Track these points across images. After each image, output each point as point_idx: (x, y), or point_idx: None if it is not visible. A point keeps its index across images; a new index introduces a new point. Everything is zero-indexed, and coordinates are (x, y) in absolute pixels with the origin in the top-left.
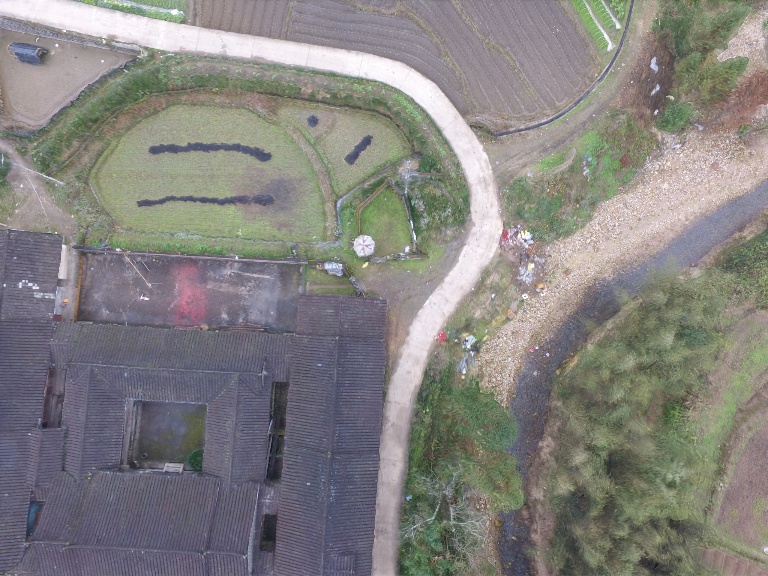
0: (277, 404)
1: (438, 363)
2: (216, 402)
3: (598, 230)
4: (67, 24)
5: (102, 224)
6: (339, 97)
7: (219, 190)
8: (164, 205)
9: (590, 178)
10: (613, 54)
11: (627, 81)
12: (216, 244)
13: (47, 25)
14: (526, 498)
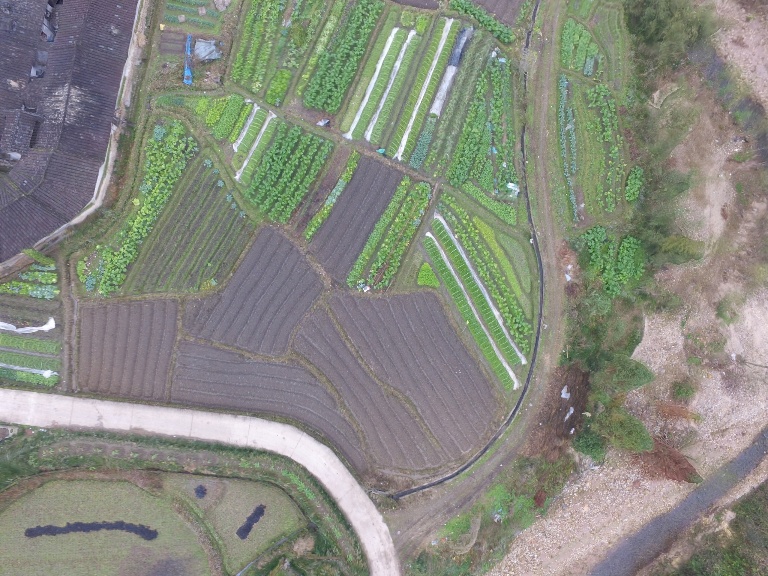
0: None
1: None
2: None
3: (516, 563)
4: None
5: None
6: None
7: (102, 575)
8: None
9: (503, 518)
10: (520, 394)
11: (535, 423)
12: None
13: None
14: None
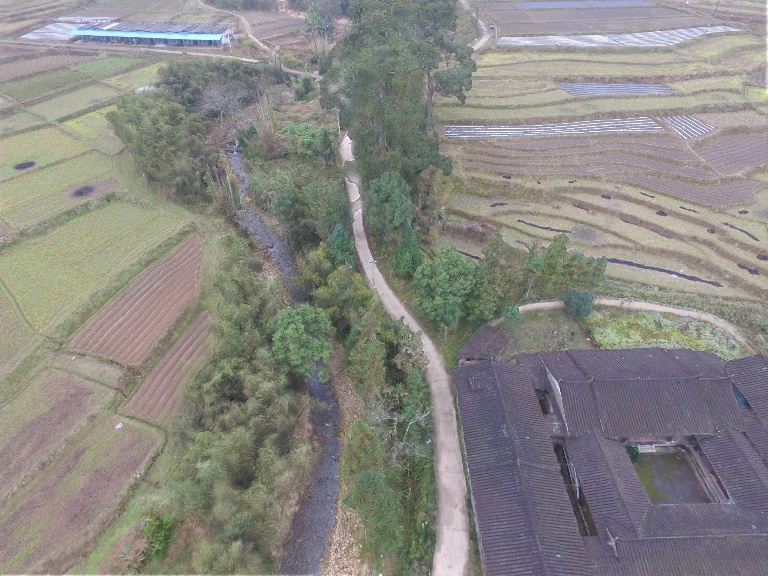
0: (579, 517)
1: None
2: (645, 507)
3: None
4: None
5: None
6: None
7: None
8: None
9: None
10: None
11: None
12: None
13: None
14: (315, 457)
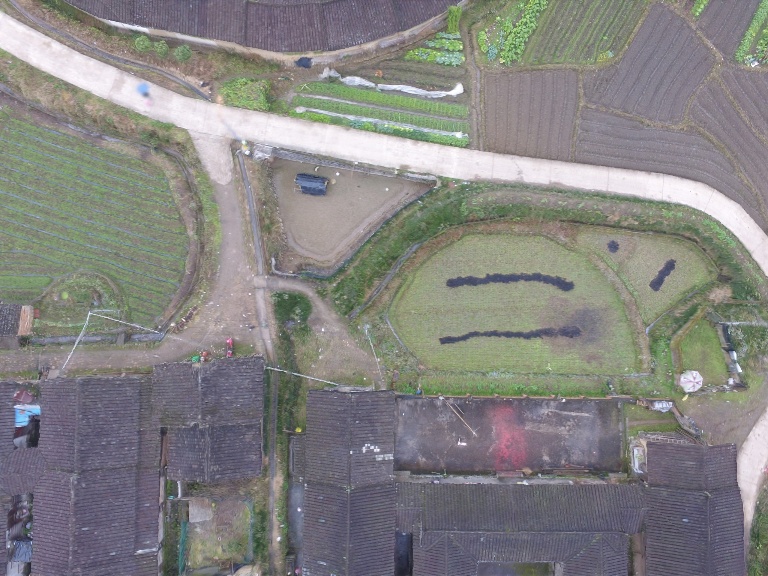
0: None
1: (766, 496)
2: (574, 561)
3: None
4: (359, 156)
5: (412, 367)
6: (646, 223)
7: (523, 323)
8: (468, 341)
9: None
10: None
11: None
12: (530, 382)
13: (339, 158)
14: None
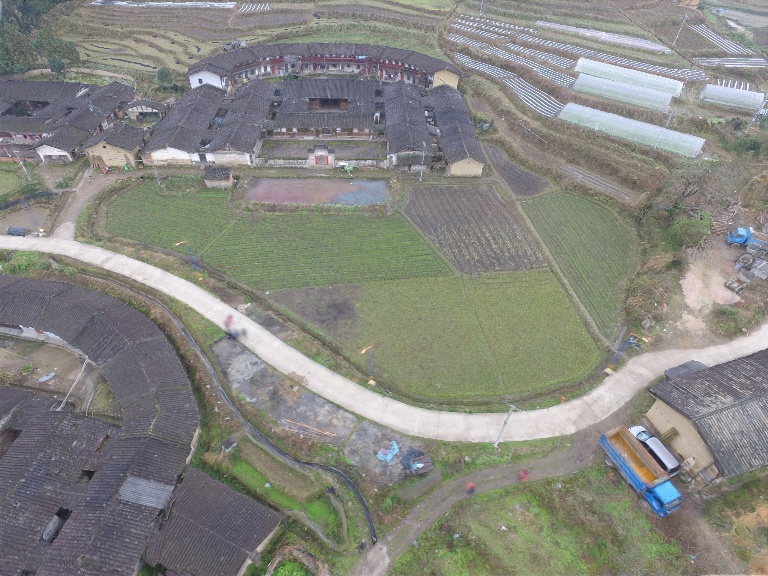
0: None
1: None
2: None
3: None
4: None
5: None
6: None
7: None
8: None
9: None
10: None
11: None
12: None
13: None
14: None
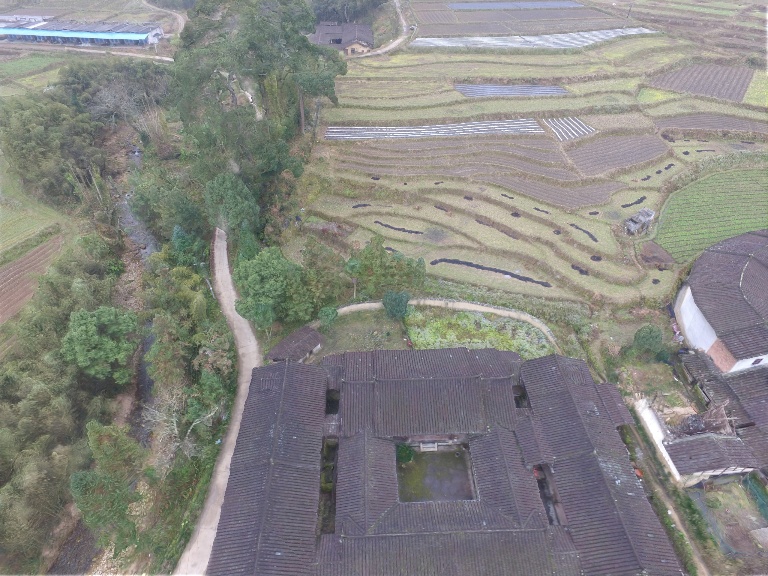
0: None
1: None
2: (389, 505)
3: None
4: None
5: None
6: None
7: None
8: None
9: None
10: None
11: None
12: None
13: None
14: None
